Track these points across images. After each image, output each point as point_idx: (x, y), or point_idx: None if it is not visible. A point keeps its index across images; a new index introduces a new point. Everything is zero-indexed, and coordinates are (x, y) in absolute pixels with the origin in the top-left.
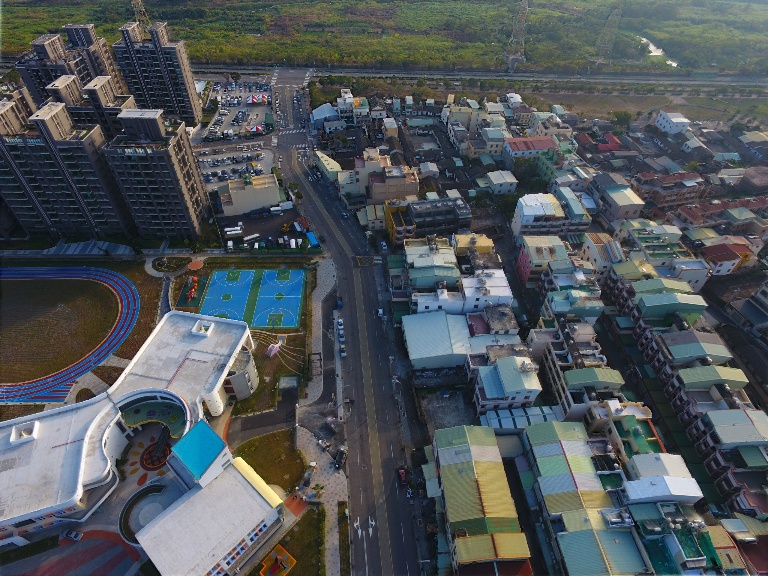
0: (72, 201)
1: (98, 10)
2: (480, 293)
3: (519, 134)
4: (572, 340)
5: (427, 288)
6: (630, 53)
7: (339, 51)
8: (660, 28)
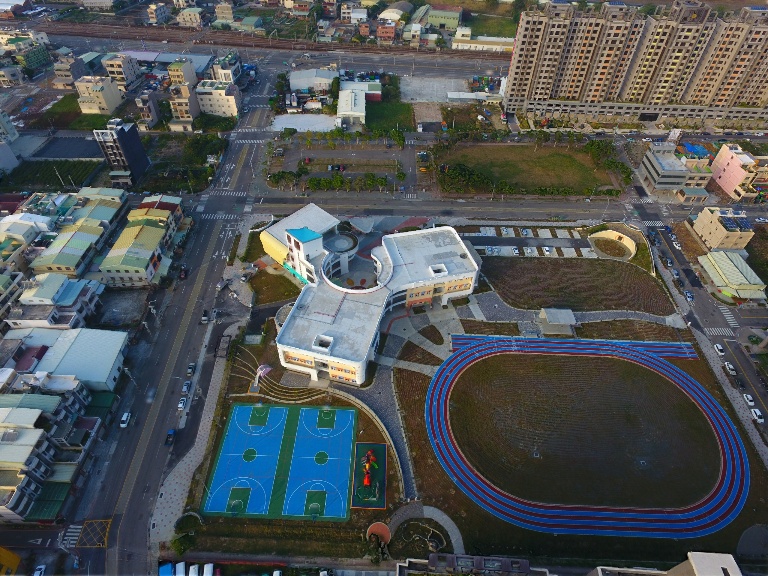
0: None
1: None
2: None
3: None
4: None
5: None
6: None
7: None
8: None
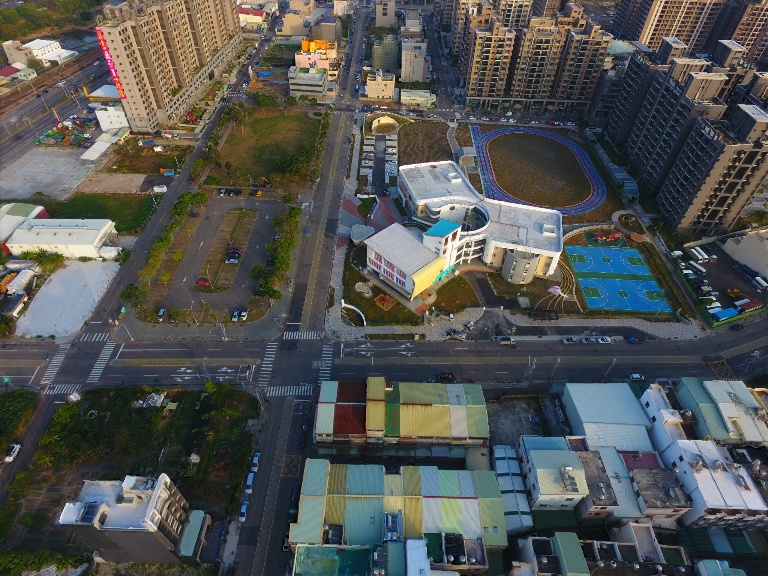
0: (654, 145)
1: None
2: (692, 459)
3: None
4: (644, 574)
5: (680, 405)
6: None
7: None
8: None
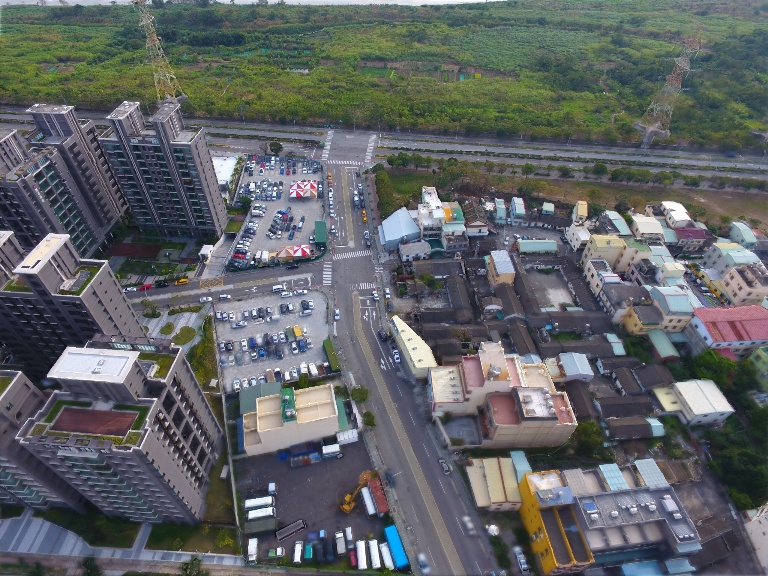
0: None
1: (120, 32)
2: None
3: (693, 278)
4: None
5: None
6: None
7: (408, 101)
8: None
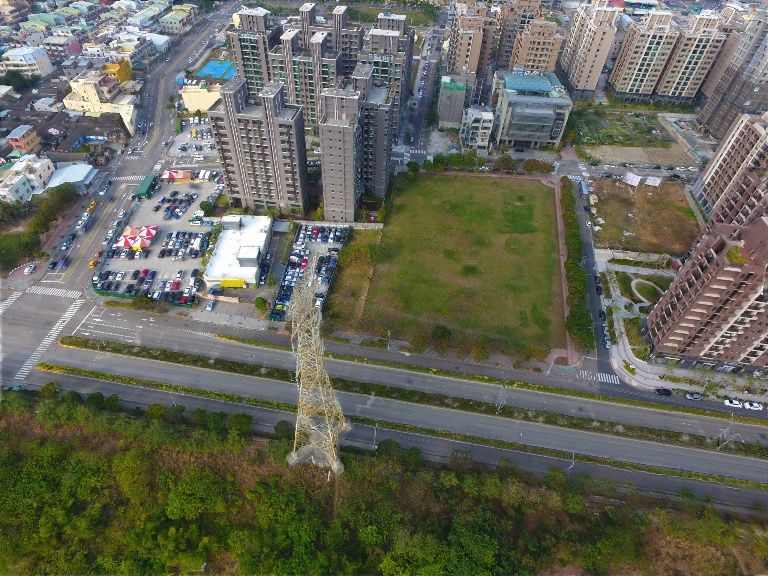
0: None
1: None
2: None
3: None
4: None
5: None
6: None
7: None
8: None
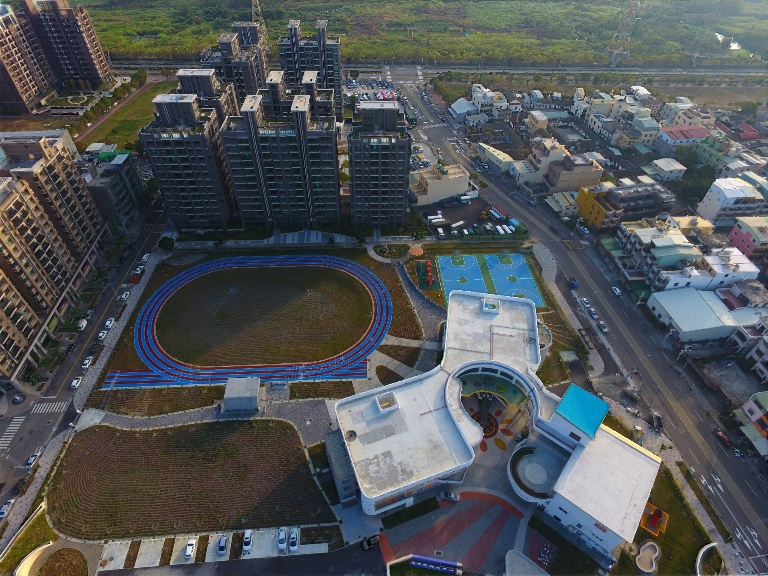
0: (299, 191)
1: (178, 12)
2: (729, 269)
3: None
4: None
5: (669, 266)
6: (715, 47)
7: (433, 49)
8: (730, 23)
